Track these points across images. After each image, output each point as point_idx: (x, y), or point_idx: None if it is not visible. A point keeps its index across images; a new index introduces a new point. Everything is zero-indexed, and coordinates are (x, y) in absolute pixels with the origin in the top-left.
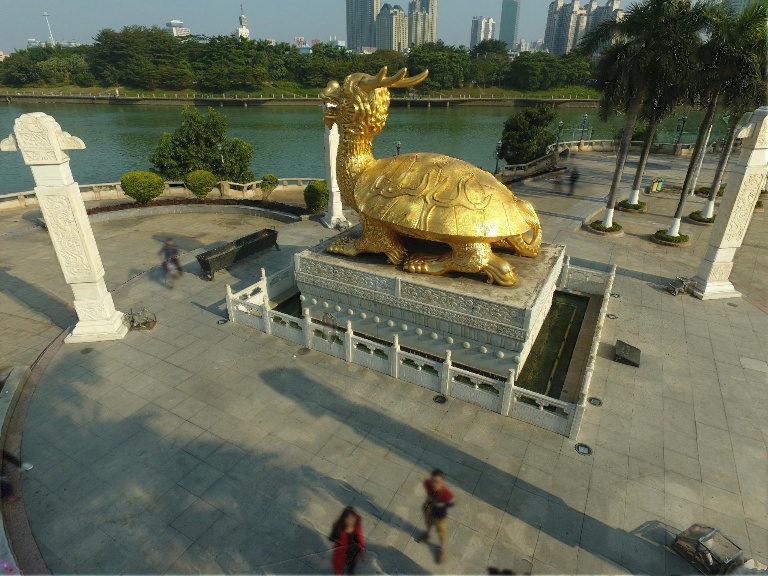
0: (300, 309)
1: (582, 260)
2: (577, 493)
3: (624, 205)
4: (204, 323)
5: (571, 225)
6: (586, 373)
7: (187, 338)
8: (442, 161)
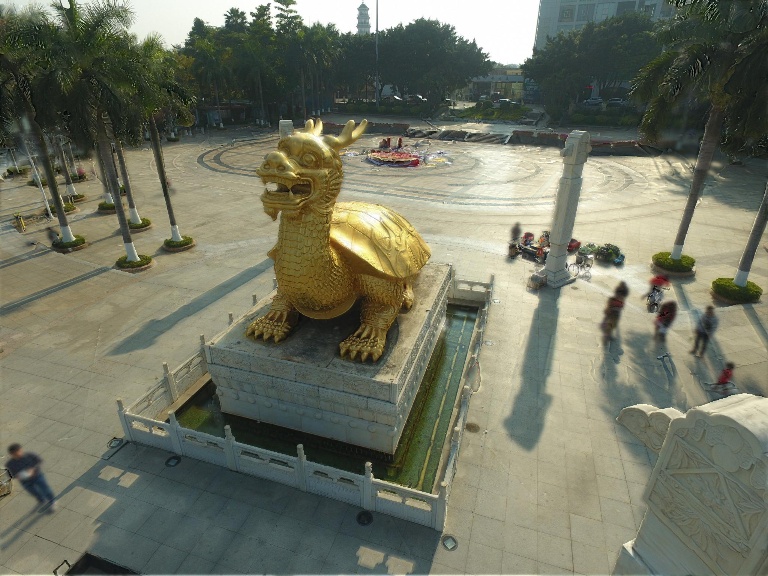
0: (362, 473)
1: (235, 278)
2: (528, 305)
3: (71, 245)
4: (463, 569)
5: (125, 275)
6: (457, 280)
7: (512, 570)
8: (362, 205)
